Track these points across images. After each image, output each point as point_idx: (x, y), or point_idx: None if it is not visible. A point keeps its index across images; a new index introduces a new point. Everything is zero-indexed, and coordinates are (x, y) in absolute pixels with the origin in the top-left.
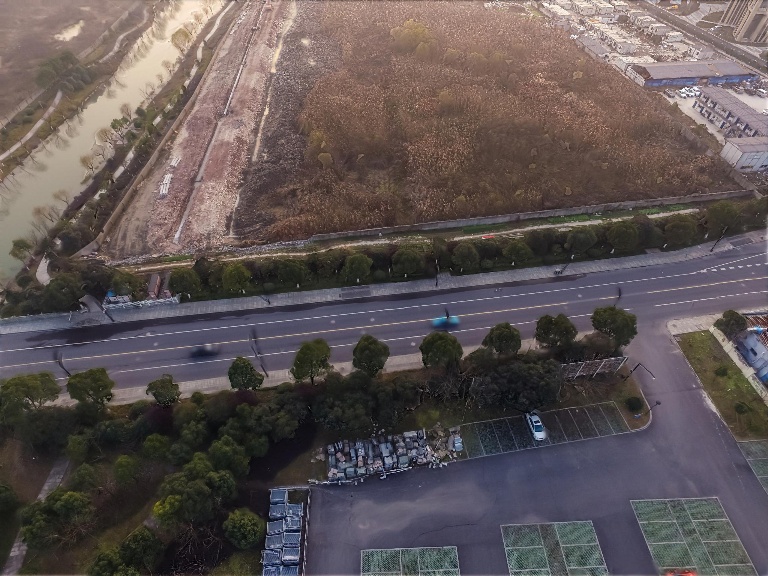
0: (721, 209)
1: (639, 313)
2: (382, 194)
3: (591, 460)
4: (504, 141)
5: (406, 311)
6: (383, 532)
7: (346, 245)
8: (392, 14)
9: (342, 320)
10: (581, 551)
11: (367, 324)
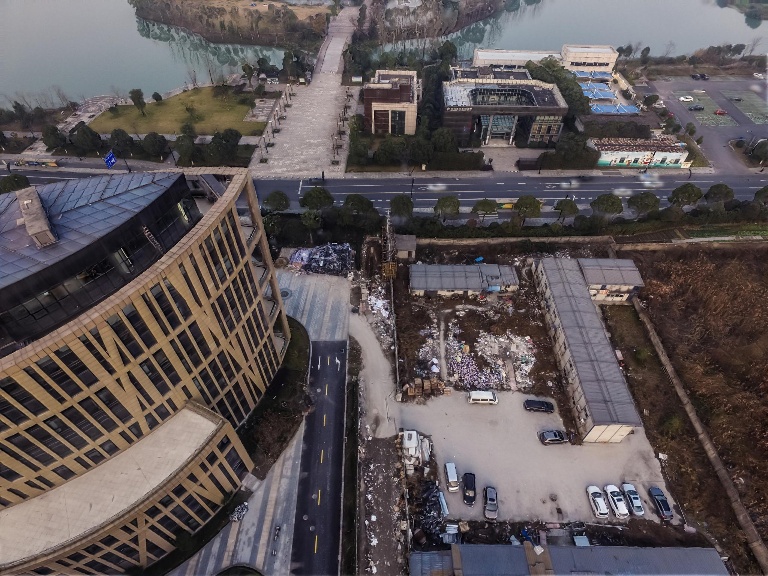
0: (697, 188)
1: (734, 178)
2: None
3: (759, 134)
4: None
5: None
6: None
7: None
8: None
9: None
10: (759, 119)
11: None
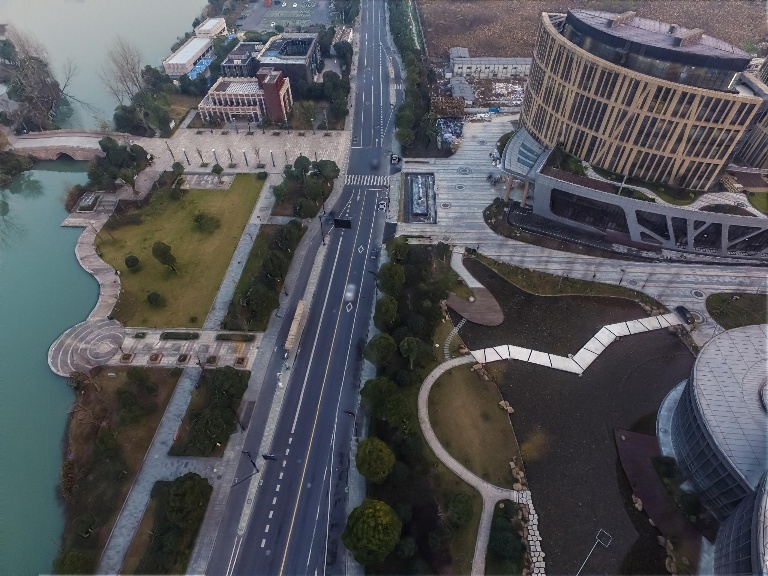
0: None
1: None
2: (437, 2)
3: None
4: (466, 10)
5: (378, 6)
6: (319, 3)
7: (410, 0)
8: (682, 7)
9: (377, 0)
10: None
11: (374, 2)
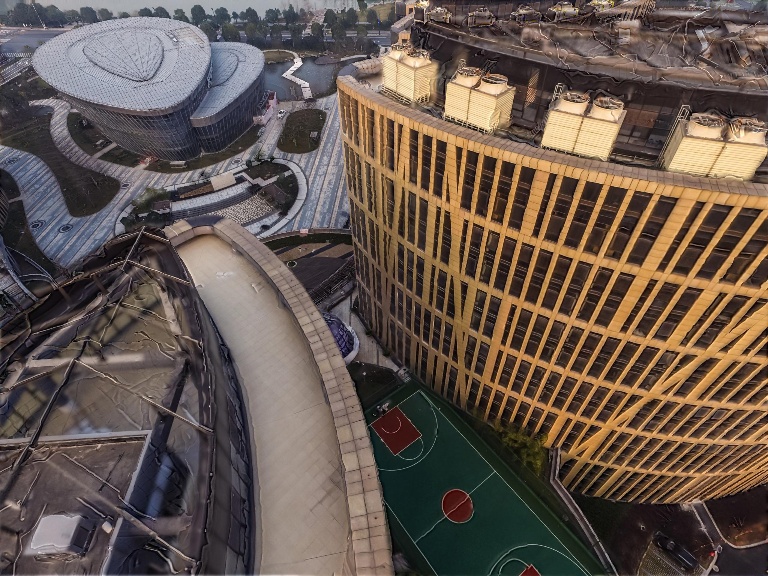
0: None
1: None
2: None
3: None
4: None
5: None
6: None
7: None
8: None
9: None
10: (756, 3)
11: None
